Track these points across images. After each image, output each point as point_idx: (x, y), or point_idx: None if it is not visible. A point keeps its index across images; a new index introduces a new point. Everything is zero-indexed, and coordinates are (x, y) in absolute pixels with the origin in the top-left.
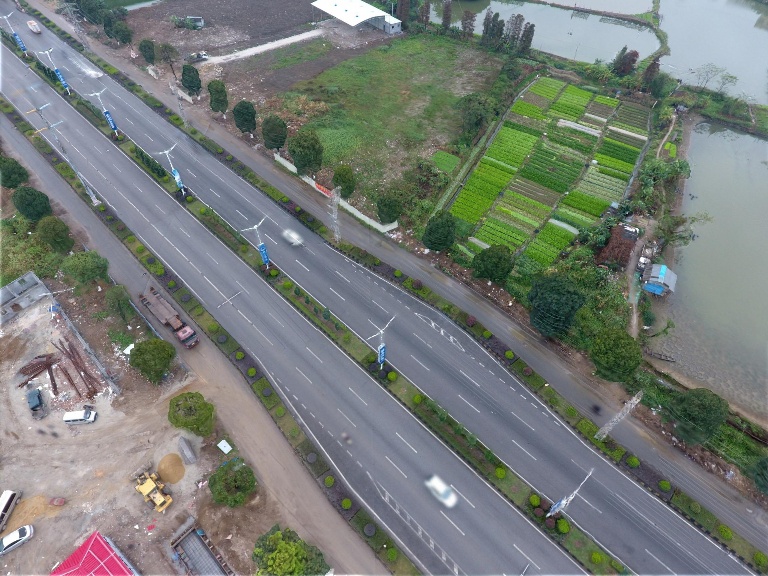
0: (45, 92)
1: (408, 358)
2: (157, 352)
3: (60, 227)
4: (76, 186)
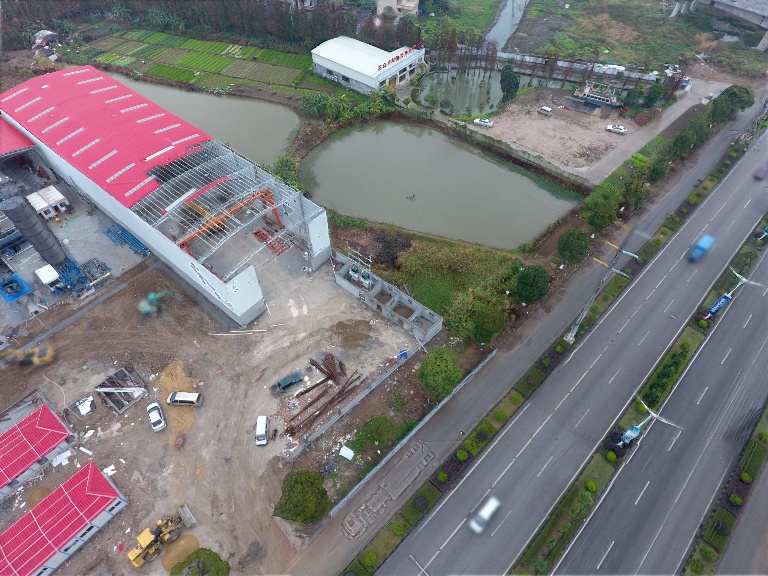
0: (750, 215)
1: None
2: (290, 508)
3: (488, 327)
4: (592, 307)
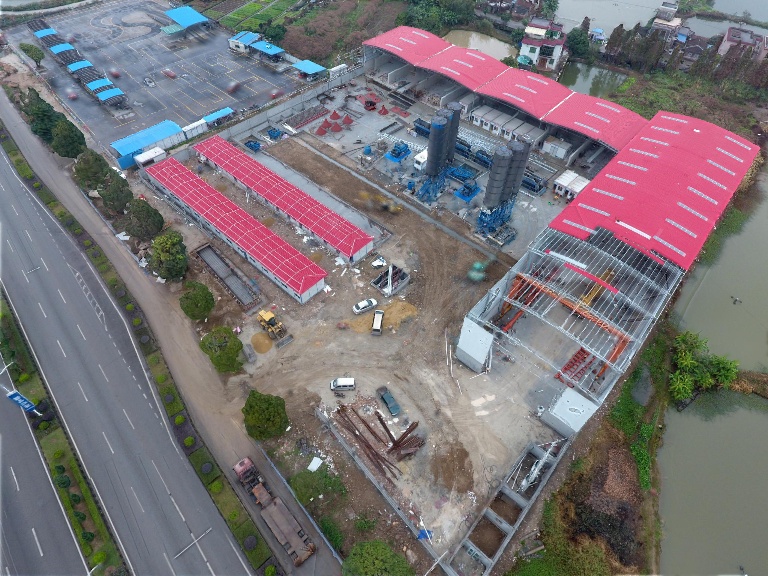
0: None
1: (5, 430)
2: (250, 401)
3: None
4: None
